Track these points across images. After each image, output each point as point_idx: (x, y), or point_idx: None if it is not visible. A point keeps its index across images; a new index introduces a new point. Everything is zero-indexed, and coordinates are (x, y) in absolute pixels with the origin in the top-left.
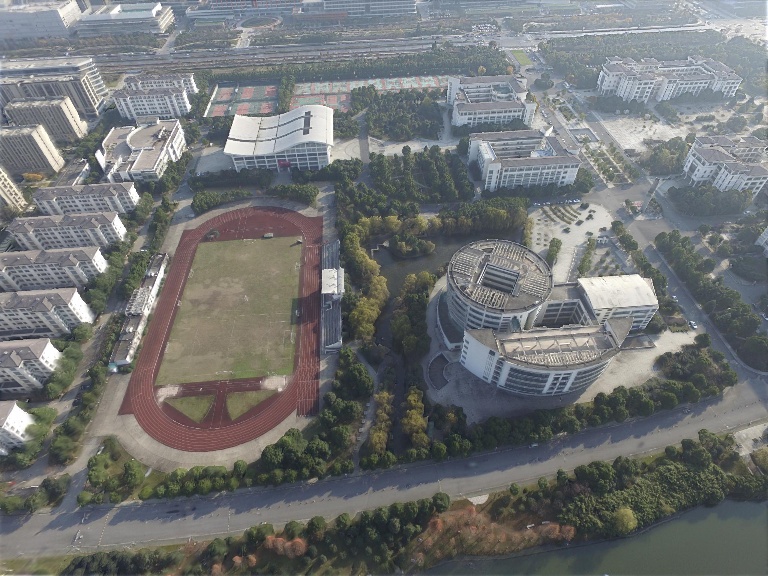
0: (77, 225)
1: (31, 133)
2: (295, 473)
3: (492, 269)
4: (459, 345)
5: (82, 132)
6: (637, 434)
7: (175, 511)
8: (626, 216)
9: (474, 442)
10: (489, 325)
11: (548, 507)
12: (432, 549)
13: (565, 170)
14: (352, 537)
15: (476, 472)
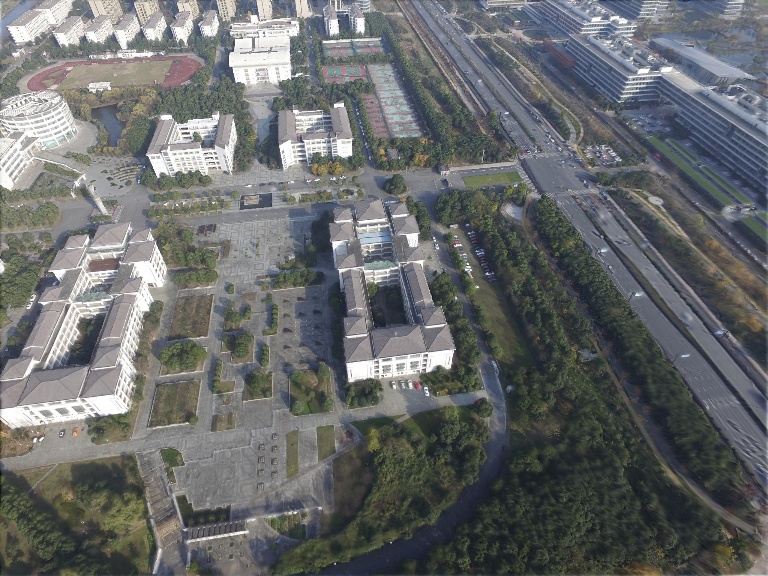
0: None
1: None
2: None
3: None
4: None
5: (303, 16)
6: None
7: None
8: None
9: None
10: None
11: None
12: None
13: None
14: None
15: None
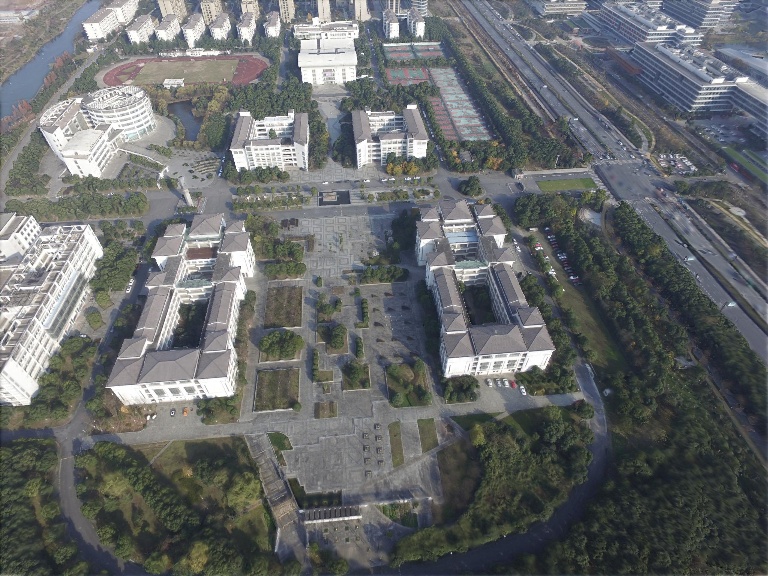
0: None
1: None
2: None
3: None
4: None
5: (361, 19)
6: None
7: None
8: None
9: None
10: None
11: None
12: None
13: None
14: None
15: None
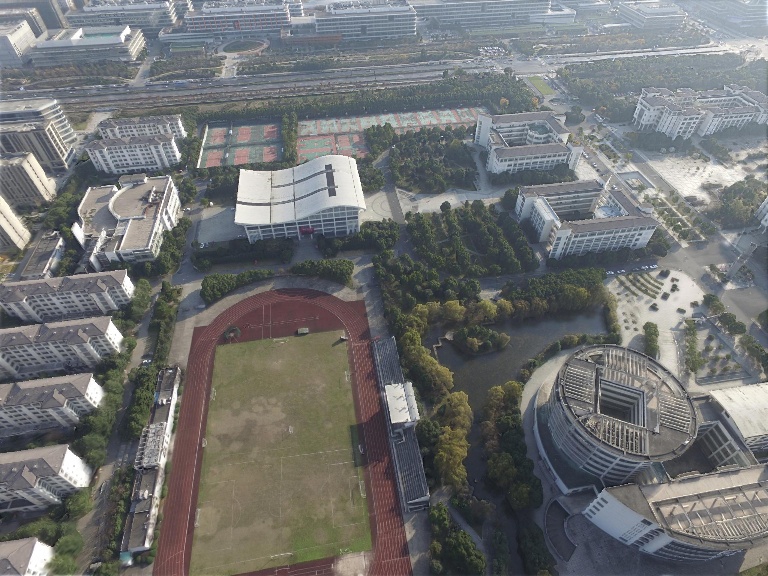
0: (59, 340)
1: None
2: None
3: (605, 384)
4: (578, 489)
5: (50, 193)
6: None
7: None
8: (714, 285)
9: None
10: (621, 468)
11: None
12: None
13: (640, 232)
14: None
15: None
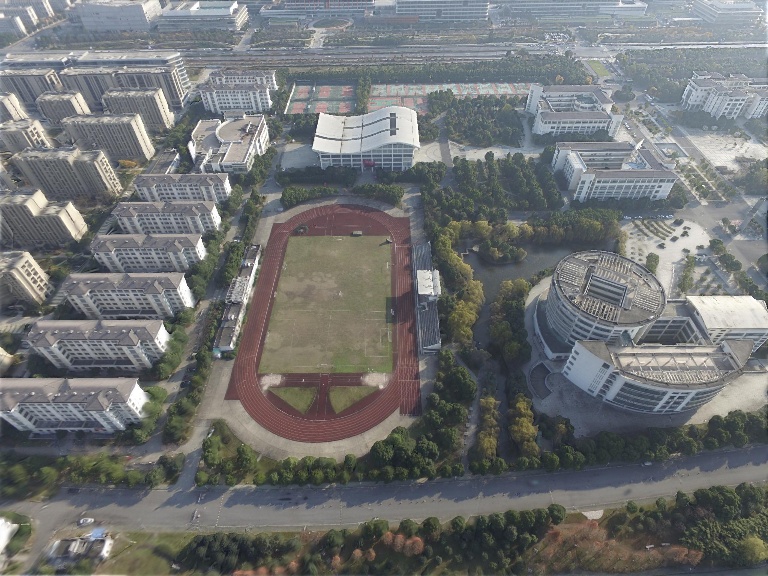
0: (178, 212)
1: (130, 121)
2: (406, 471)
3: (596, 281)
4: (561, 355)
5: (170, 123)
6: (756, 461)
7: (287, 499)
8: (723, 235)
9: (587, 455)
10: (596, 337)
11: (668, 529)
12: (549, 561)
13: (660, 184)
14: (467, 541)
15: (588, 486)
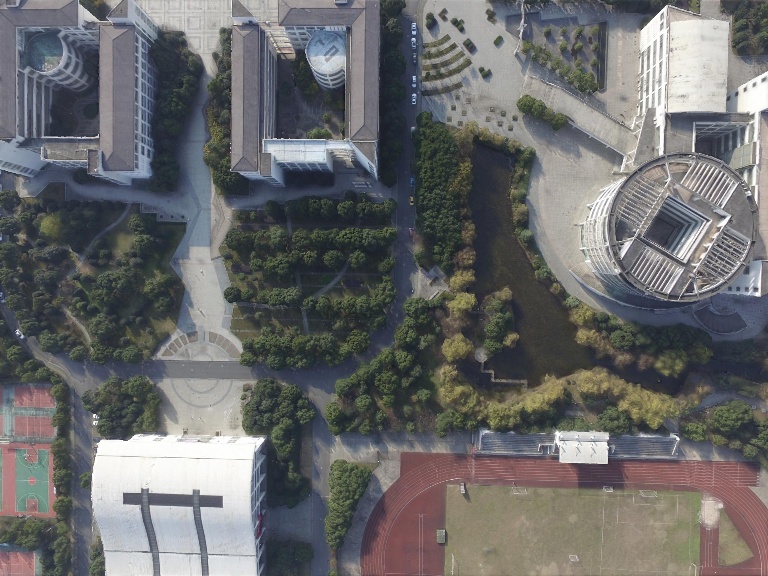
0: None
1: None
2: None
3: None
4: None
5: None
6: None
7: None
8: None
9: None
10: None
11: None
12: None
13: None
14: None
15: None
